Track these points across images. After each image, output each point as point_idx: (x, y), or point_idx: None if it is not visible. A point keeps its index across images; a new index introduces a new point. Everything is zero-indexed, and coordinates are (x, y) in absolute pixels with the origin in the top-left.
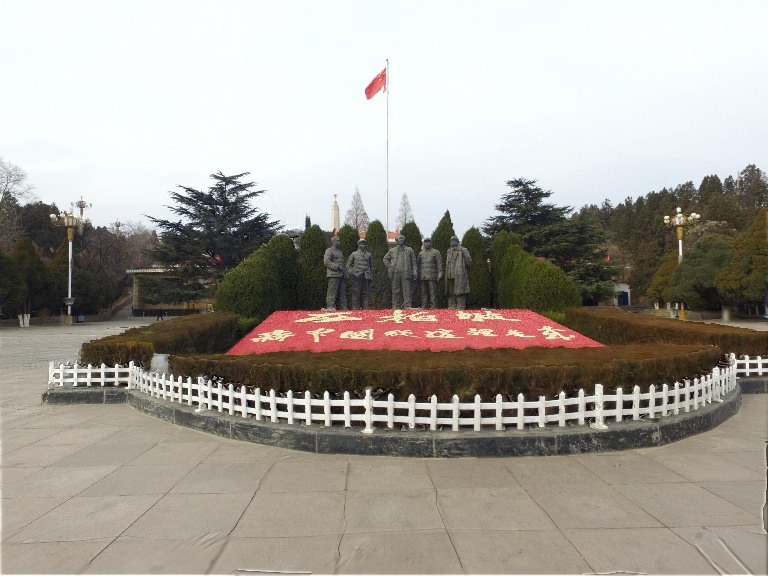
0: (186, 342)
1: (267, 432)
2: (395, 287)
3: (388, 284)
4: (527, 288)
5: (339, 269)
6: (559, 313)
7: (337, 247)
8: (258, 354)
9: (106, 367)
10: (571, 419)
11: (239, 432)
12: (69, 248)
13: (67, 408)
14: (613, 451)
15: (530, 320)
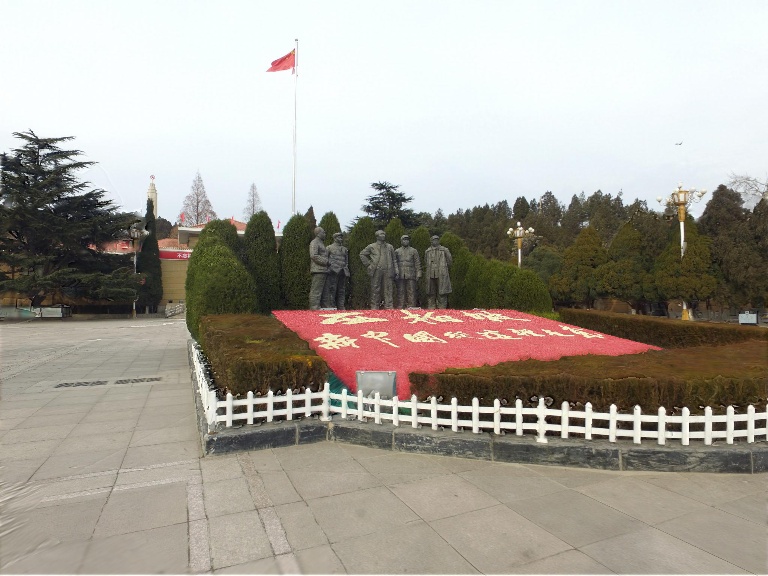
0: None
1: (680, 457)
2: (376, 285)
3: (346, 281)
4: (500, 289)
5: (328, 264)
6: (540, 313)
7: (322, 239)
8: (507, 366)
9: (293, 393)
10: None
11: (634, 461)
12: None
13: (268, 457)
14: None
15: (538, 320)
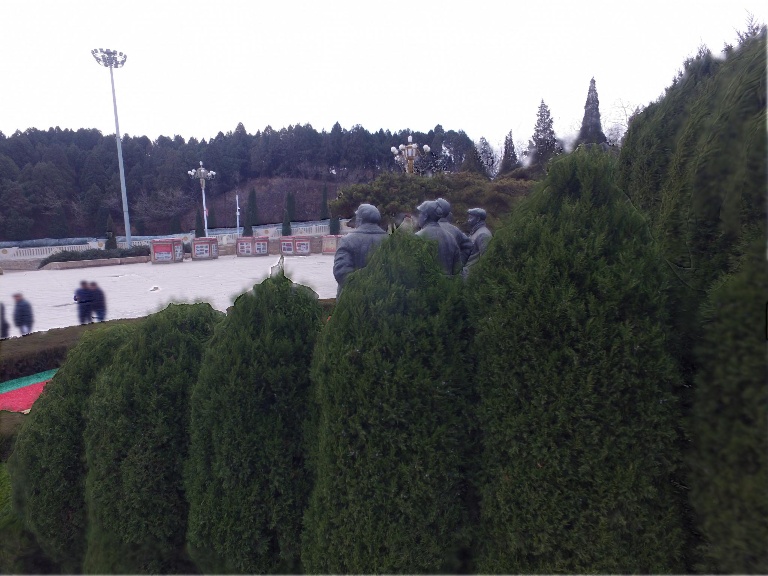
0: None
1: None
2: None
3: None
4: None
5: None
6: None
7: None
8: None
9: None
10: None
11: None
12: None
13: None
14: None
15: None
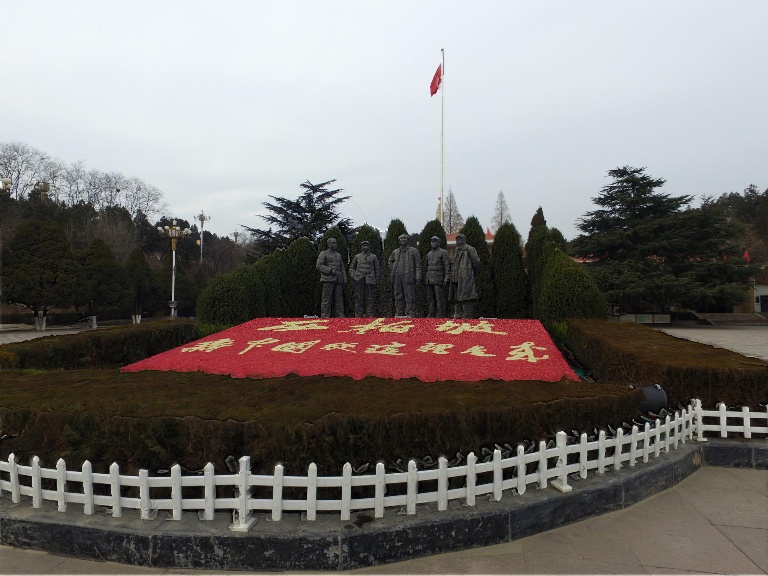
0: (81, 351)
1: None
2: (396, 292)
3: None
4: None
5: (332, 273)
6: None
7: (333, 249)
8: None
9: None
10: (196, 509)
11: None
12: (173, 256)
13: None
14: (248, 570)
15: (518, 334)
